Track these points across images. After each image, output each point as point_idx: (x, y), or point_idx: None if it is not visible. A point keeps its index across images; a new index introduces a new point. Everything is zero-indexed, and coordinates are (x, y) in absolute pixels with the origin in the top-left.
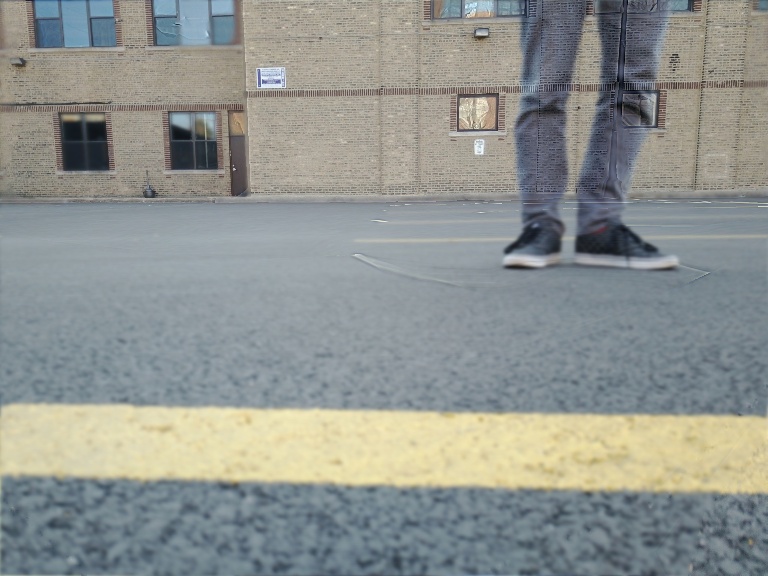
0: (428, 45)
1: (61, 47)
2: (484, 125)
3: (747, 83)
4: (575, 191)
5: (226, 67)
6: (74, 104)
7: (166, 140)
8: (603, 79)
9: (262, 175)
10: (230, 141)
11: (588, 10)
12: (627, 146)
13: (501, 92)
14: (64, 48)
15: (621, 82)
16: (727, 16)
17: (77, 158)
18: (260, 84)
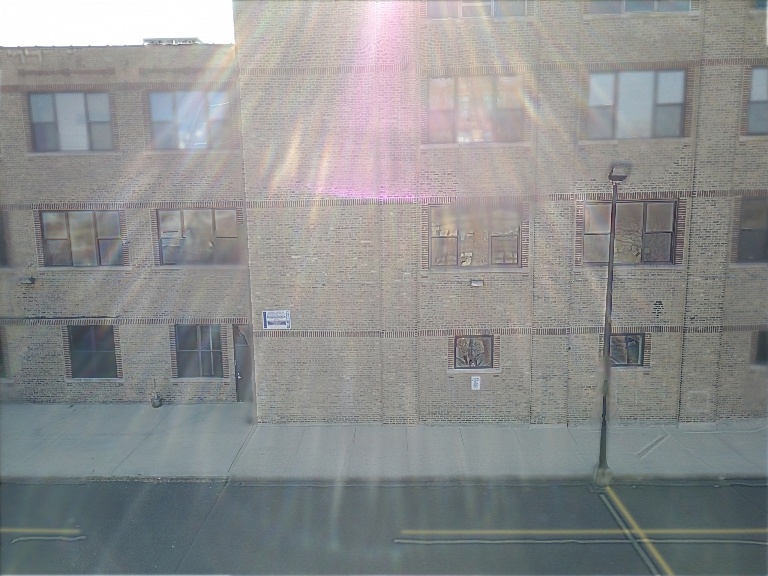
0: (426, 291)
1: (69, 266)
2: (480, 361)
3: (726, 328)
4: (566, 423)
5: (231, 285)
6: (82, 318)
7: (173, 351)
8: (592, 323)
9: (268, 407)
10: (235, 351)
11: (577, 262)
12: (615, 382)
13: (496, 334)
14: (72, 267)
15: (608, 326)
16: (706, 270)
17: (86, 366)
18: (266, 325)
